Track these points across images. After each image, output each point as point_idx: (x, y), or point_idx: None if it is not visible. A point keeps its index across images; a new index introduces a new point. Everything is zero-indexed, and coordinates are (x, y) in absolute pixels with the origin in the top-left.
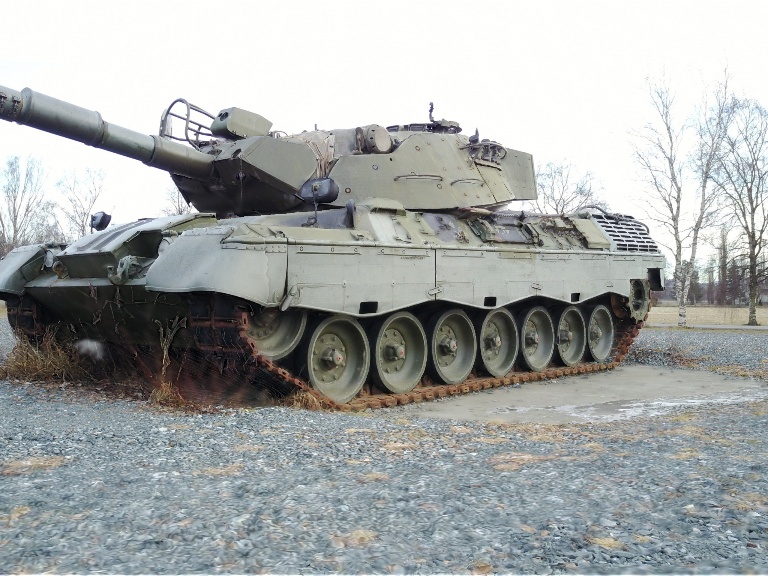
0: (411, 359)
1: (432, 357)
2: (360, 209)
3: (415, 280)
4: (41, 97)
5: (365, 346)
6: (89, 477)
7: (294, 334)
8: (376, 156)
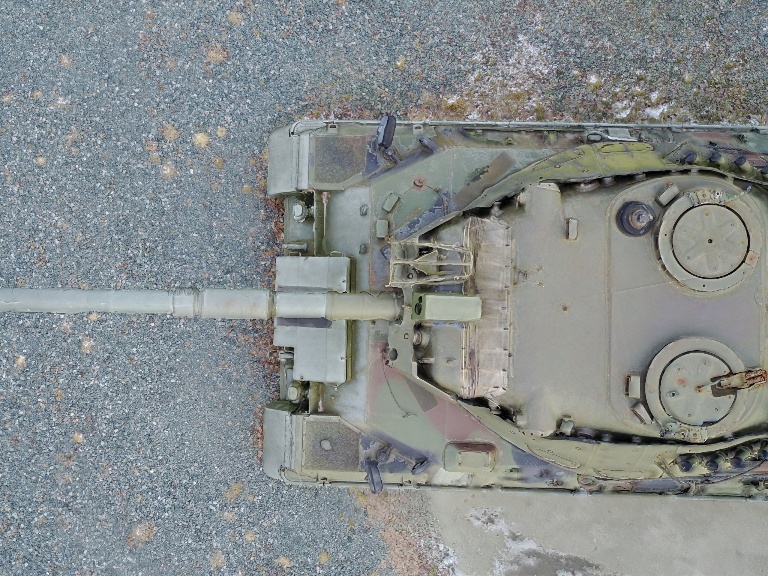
0: None
1: None
2: (438, 462)
3: None
4: (210, 315)
5: None
6: (141, 567)
7: None
8: (519, 432)
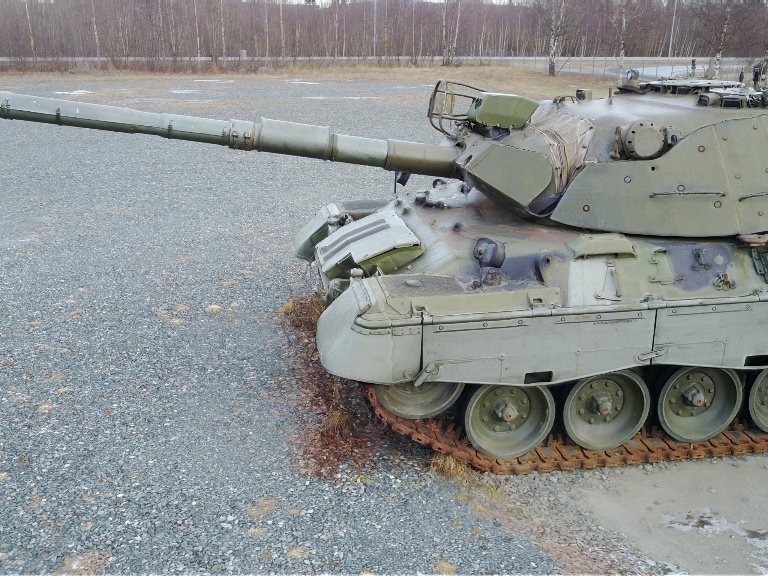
0: (628, 411)
1: (657, 413)
2: (564, 255)
3: (616, 346)
4: (271, 128)
5: (548, 404)
6: None
7: (450, 394)
8: (632, 165)
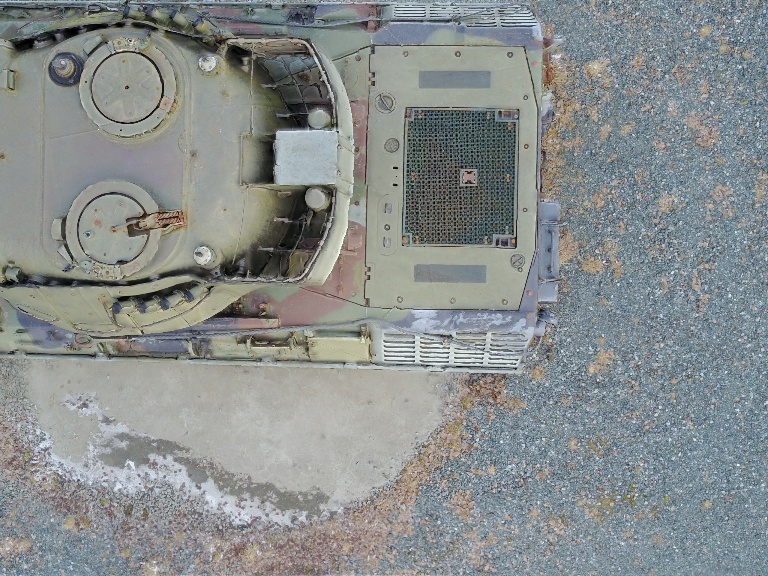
0: None
1: None
2: None
3: None
4: None
5: None
6: None
7: None
8: None
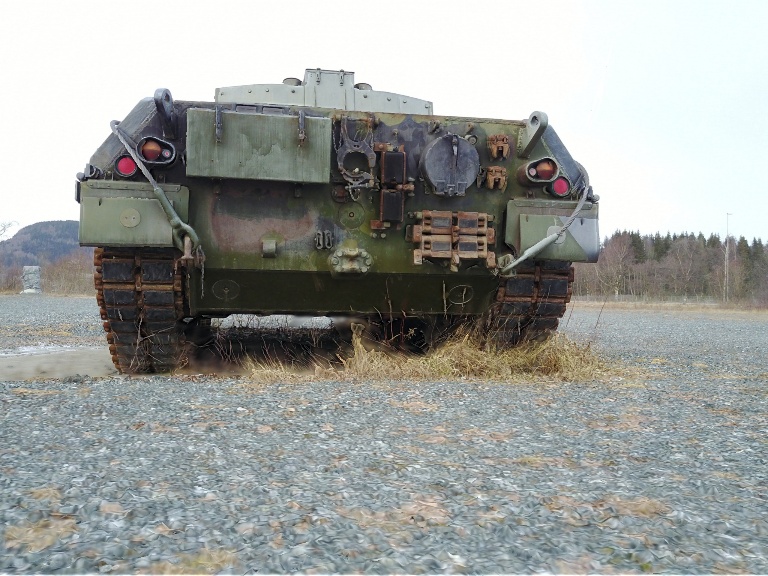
0: None
1: None
2: None
3: None
4: None
5: None
6: None
7: None
8: None
